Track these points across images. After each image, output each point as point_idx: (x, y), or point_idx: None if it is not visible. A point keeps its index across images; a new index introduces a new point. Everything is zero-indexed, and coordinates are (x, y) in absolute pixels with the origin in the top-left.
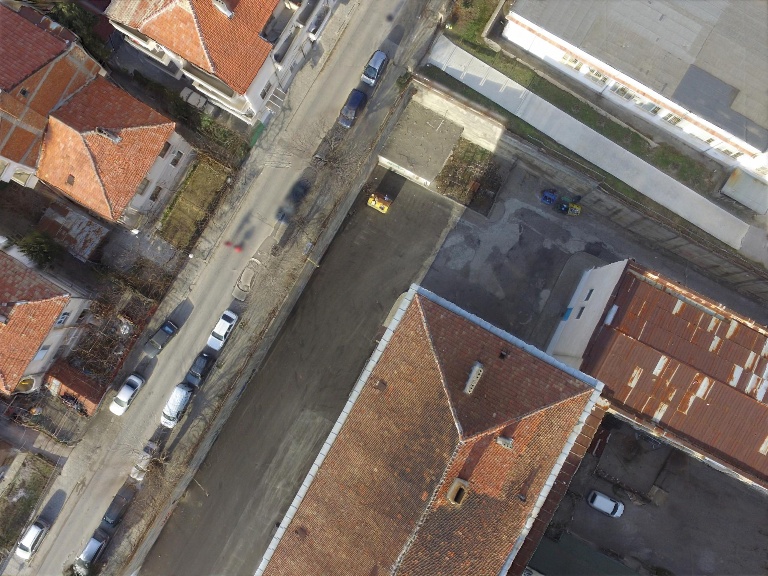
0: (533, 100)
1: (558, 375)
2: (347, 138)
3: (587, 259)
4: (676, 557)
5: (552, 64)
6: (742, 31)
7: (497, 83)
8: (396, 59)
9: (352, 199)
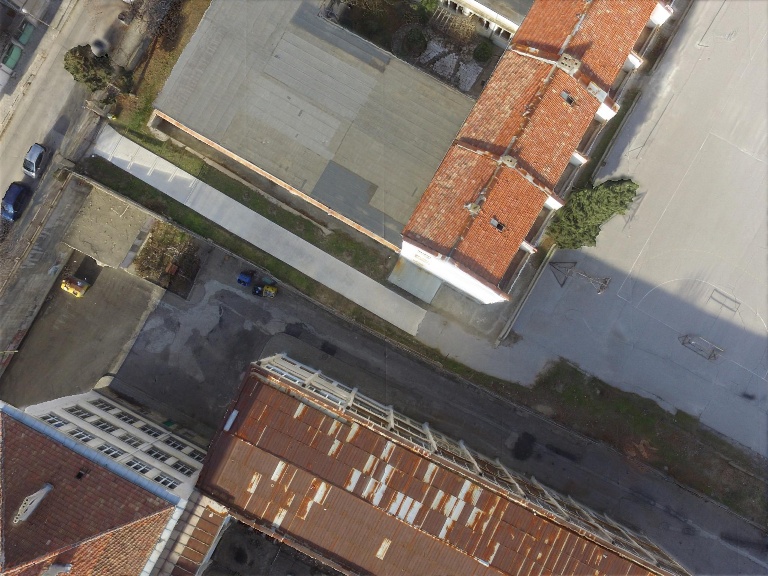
0: (203, 189)
1: (138, 493)
2: (13, 230)
3: (287, 340)
4: None
5: (223, 152)
6: (381, 126)
7: (166, 172)
8: (62, 150)
9: (44, 285)
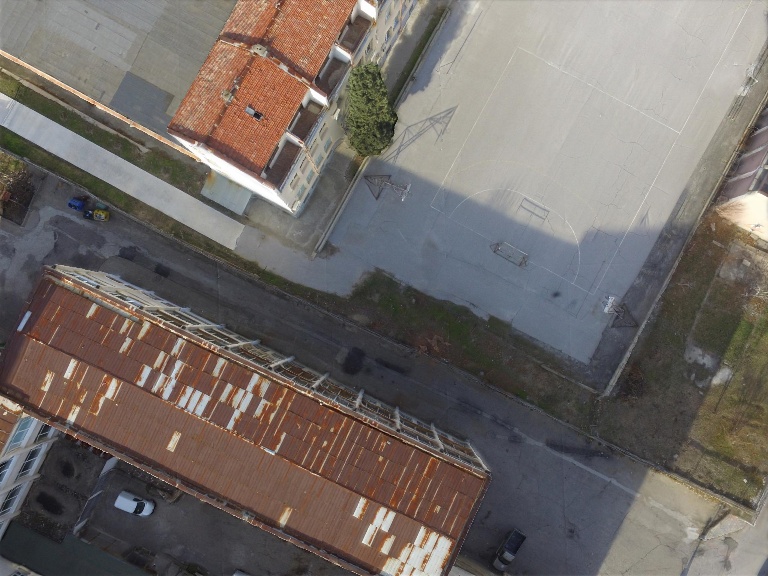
0: (20, 110)
1: None
2: None
3: (121, 263)
4: (208, 552)
5: None
6: (176, 37)
7: None
8: None
9: None
